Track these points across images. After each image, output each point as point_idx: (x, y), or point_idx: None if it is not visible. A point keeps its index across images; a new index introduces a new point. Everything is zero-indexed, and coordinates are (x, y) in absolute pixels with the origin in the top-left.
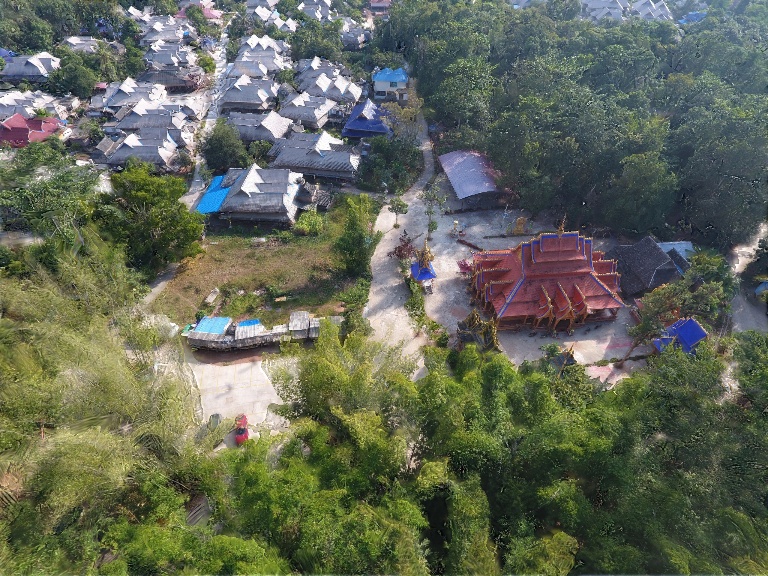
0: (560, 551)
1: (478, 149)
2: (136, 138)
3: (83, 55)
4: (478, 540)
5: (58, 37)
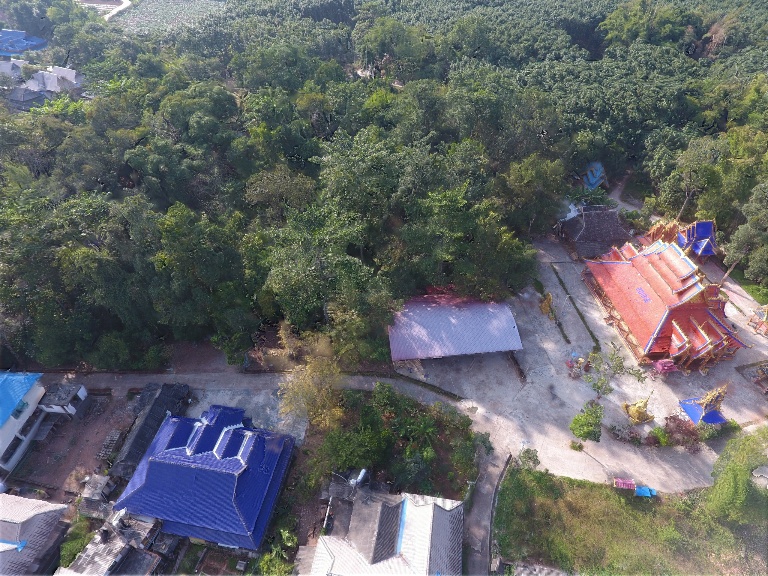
0: None
1: None
2: None
3: None
4: None
5: None
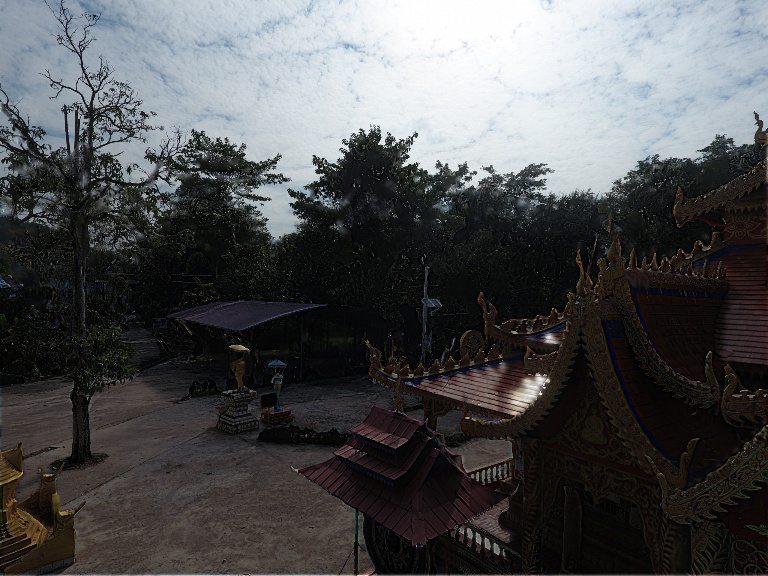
0: None
1: (268, 300)
2: None
3: None
4: None
5: None
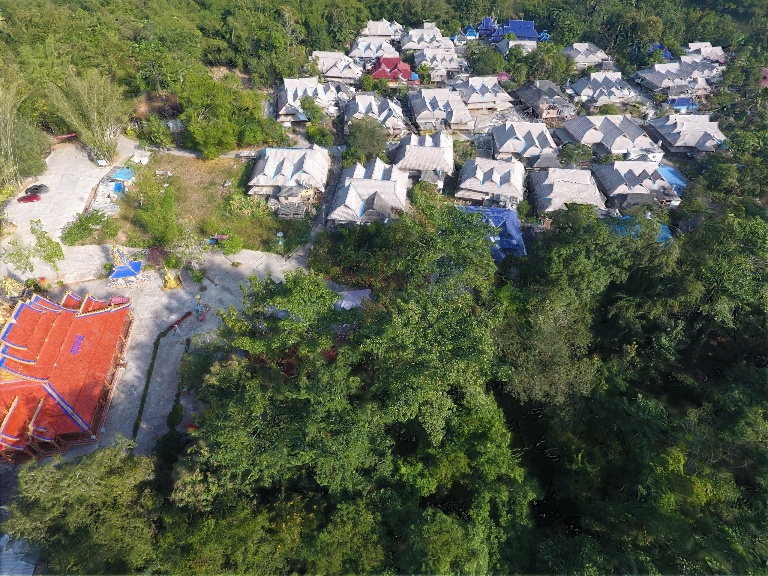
0: None
1: None
2: (371, 100)
3: (535, 53)
4: None
5: (584, 40)
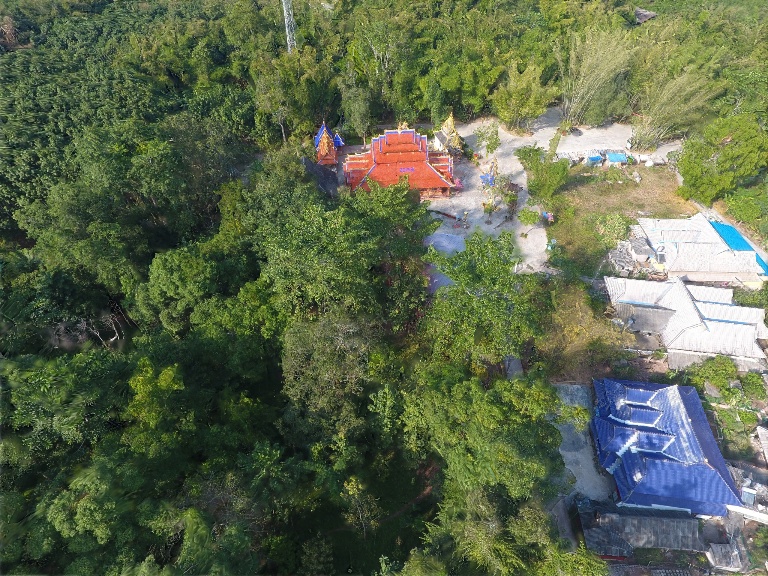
0: None
1: None
2: None
3: None
4: None
5: None
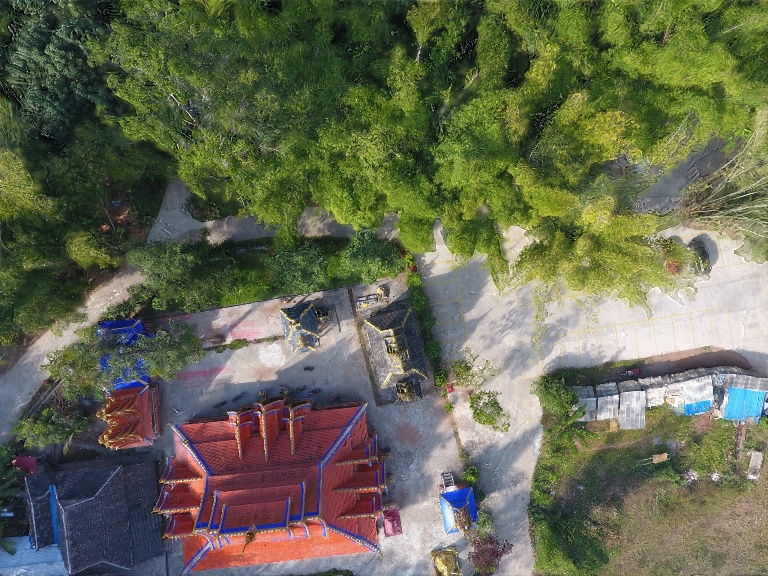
0: (428, 6)
1: None
2: None
3: None
4: (507, 4)
5: None
